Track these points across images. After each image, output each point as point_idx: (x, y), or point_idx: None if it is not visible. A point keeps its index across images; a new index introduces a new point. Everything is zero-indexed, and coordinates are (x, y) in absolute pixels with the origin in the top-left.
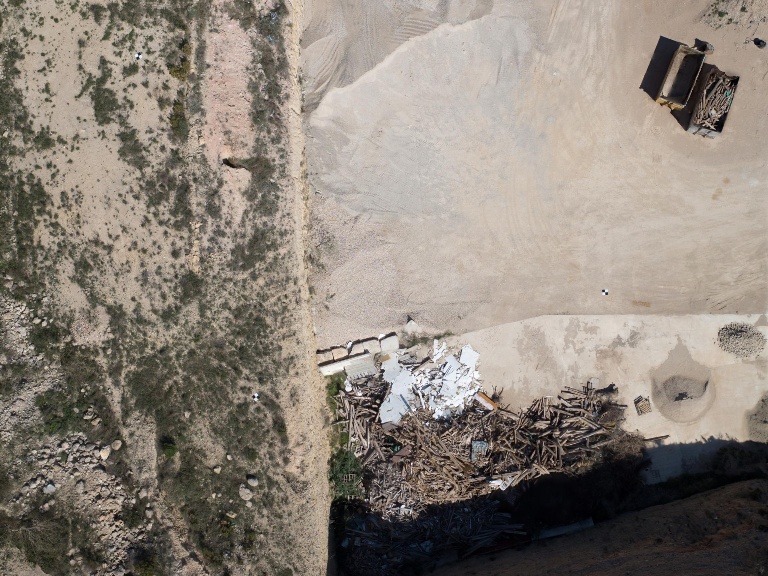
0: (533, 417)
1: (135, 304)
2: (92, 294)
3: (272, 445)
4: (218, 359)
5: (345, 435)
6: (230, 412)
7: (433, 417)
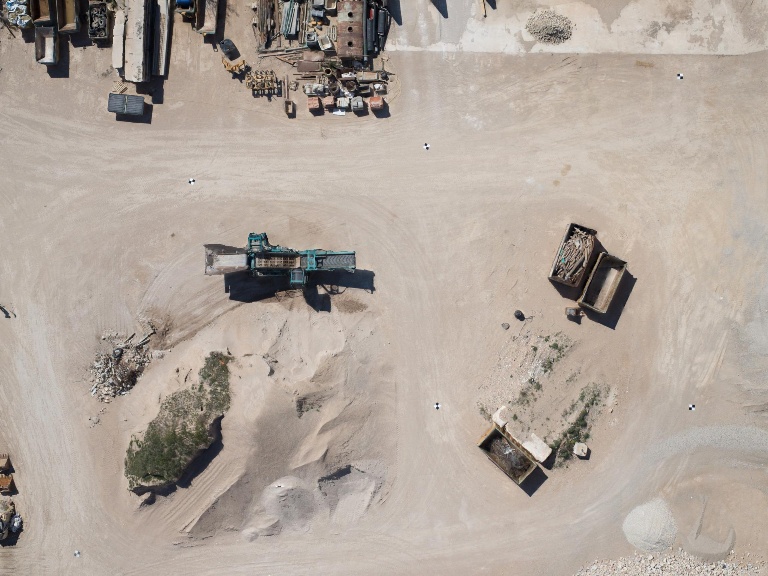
0: None
1: None
2: None
3: None
4: None
5: None
6: None
7: None
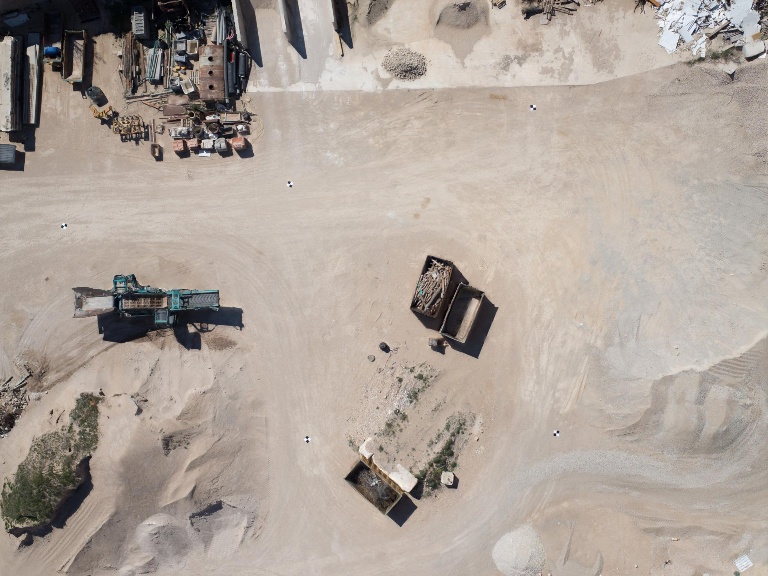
0: None
1: None
2: None
3: None
4: None
5: None
6: None
7: None
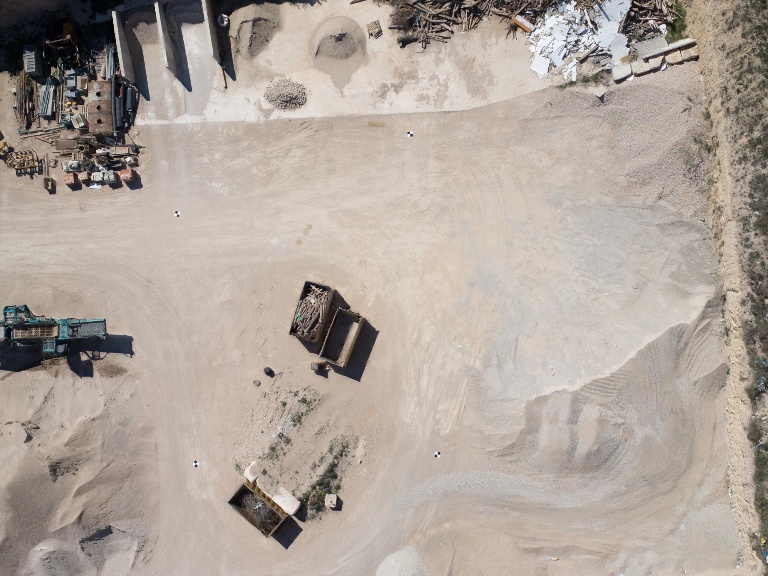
0: (477, 12)
1: None
2: None
3: None
4: None
5: None
6: None
7: (576, 2)
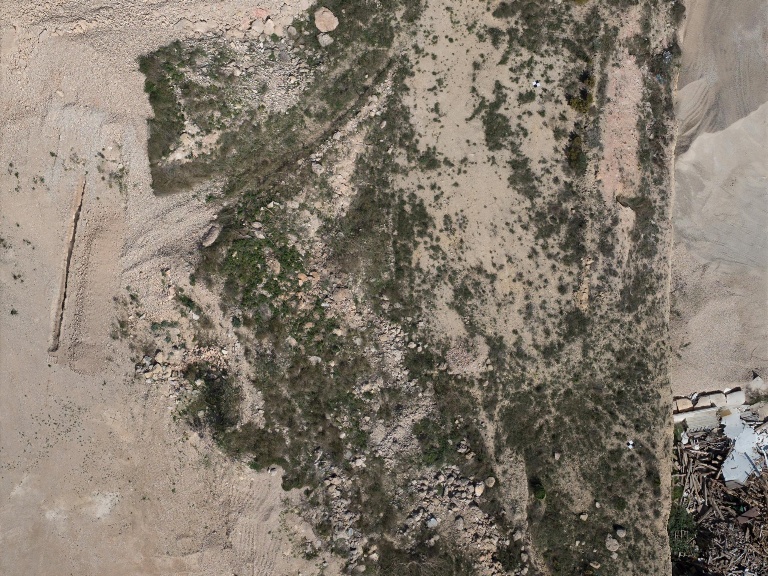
0: None
1: (516, 337)
2: (471, 323)
3: (643, 496)
4: (594, 401)
5: (679, 489)
6: (602, 458)
7: None
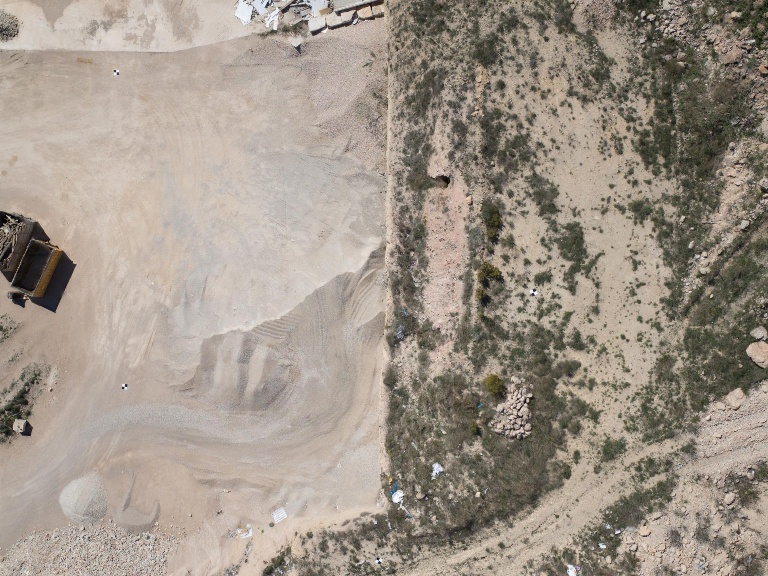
0: None
1: (545, 34)
2: (591, 45)
3: None
4: None
5: None
6: None
7: None
